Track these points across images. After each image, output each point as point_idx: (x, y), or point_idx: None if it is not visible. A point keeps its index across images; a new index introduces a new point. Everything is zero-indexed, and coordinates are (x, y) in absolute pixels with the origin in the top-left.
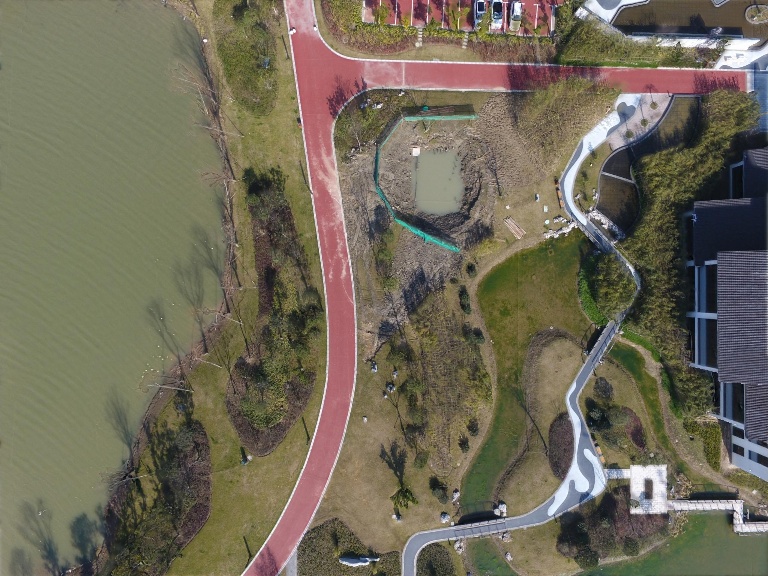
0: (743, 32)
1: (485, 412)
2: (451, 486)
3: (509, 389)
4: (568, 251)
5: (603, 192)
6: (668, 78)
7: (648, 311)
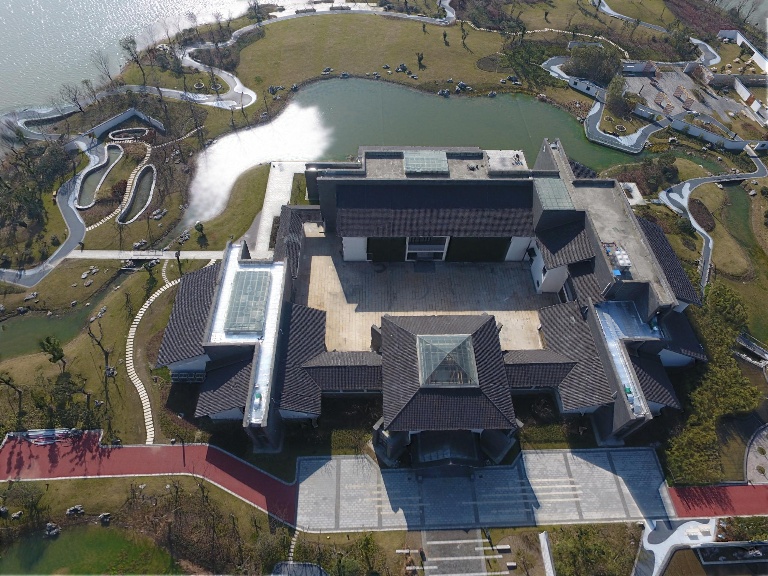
0: (703, 570)
1: (763, 233)
2: (760, 197)
3: (752, 247)
4: (762, 337)
5: (764, 383)
6: (761, 503)
7: (697, 284)
